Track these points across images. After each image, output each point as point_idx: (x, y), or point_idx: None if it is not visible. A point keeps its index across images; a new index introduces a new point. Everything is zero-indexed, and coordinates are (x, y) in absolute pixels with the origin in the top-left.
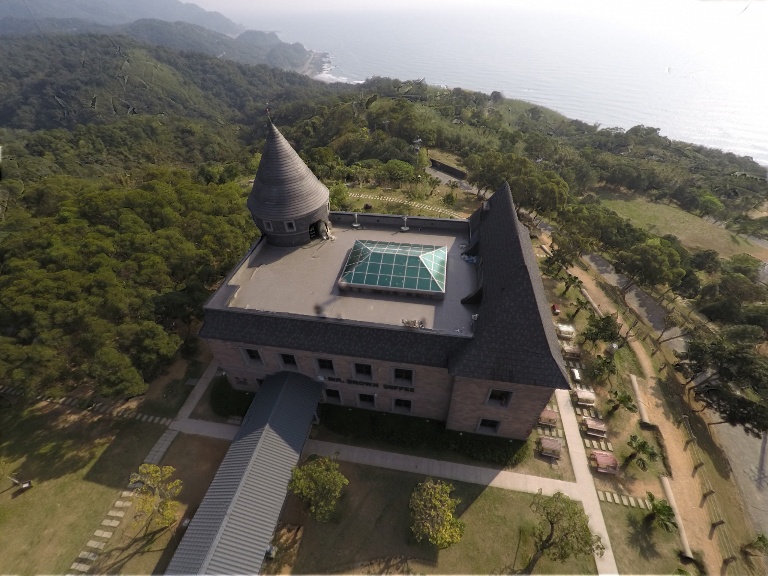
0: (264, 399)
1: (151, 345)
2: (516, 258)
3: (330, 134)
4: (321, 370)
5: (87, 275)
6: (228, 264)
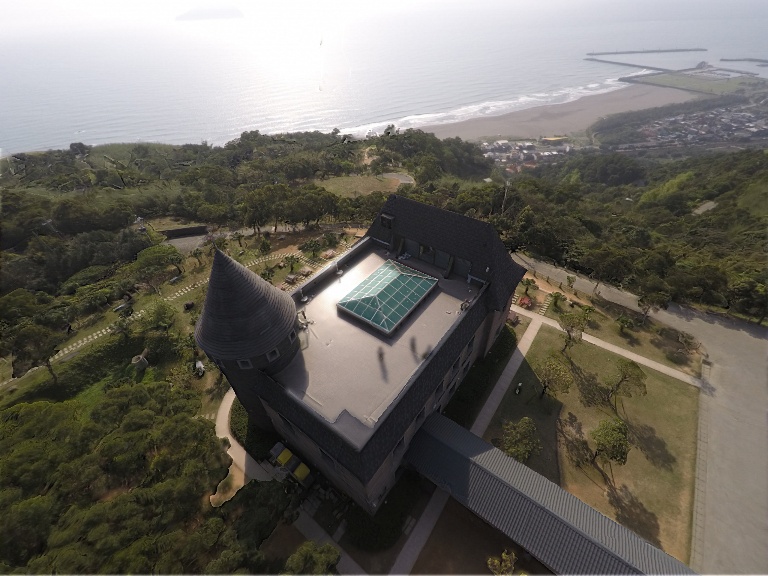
0: (435, 462)
1: (323, 570)
2: (476, 225)
3: None
4: None
5: None
6: None
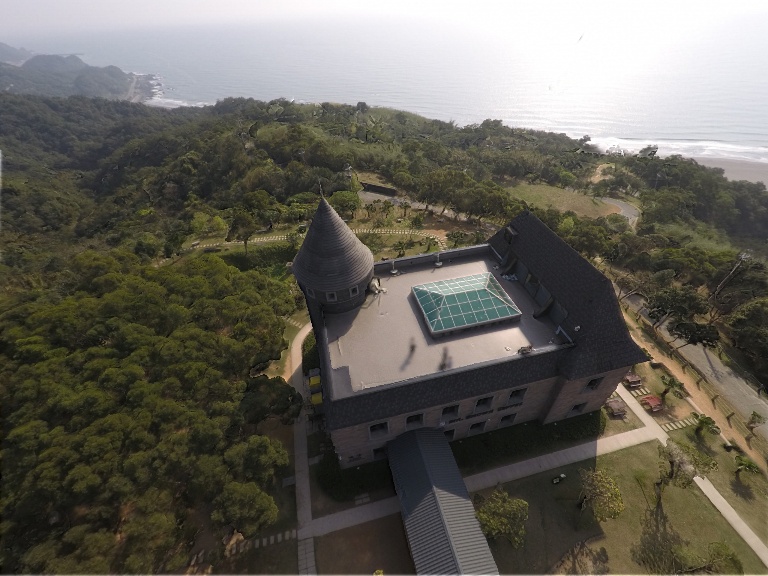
0: (405, 465)
1: (268, 461)
2: (592, 274)
3: (219, 169)
4: (442, 417)
5: (132, 413)
6: (272, 345)
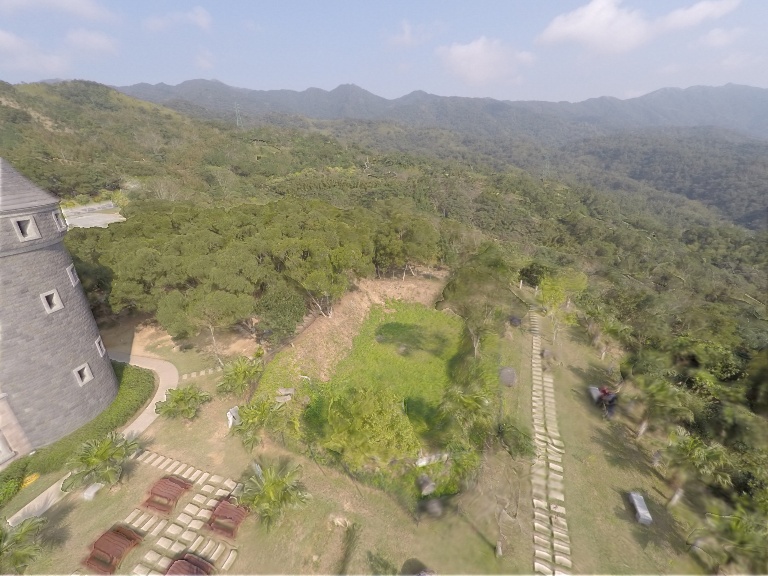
0: None
1: None
2: None
3: None
4: None
5: None
6: None
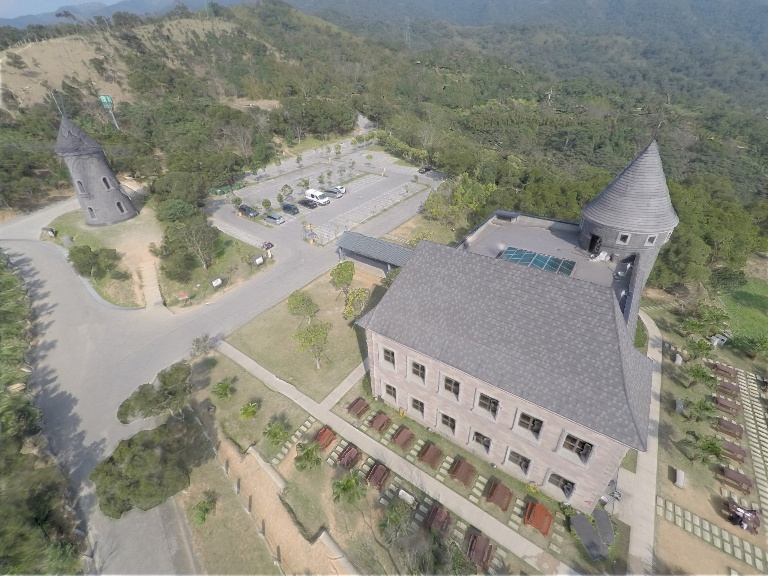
0: None
1: None
2: None
3: None
4: None
5: None
6: None
